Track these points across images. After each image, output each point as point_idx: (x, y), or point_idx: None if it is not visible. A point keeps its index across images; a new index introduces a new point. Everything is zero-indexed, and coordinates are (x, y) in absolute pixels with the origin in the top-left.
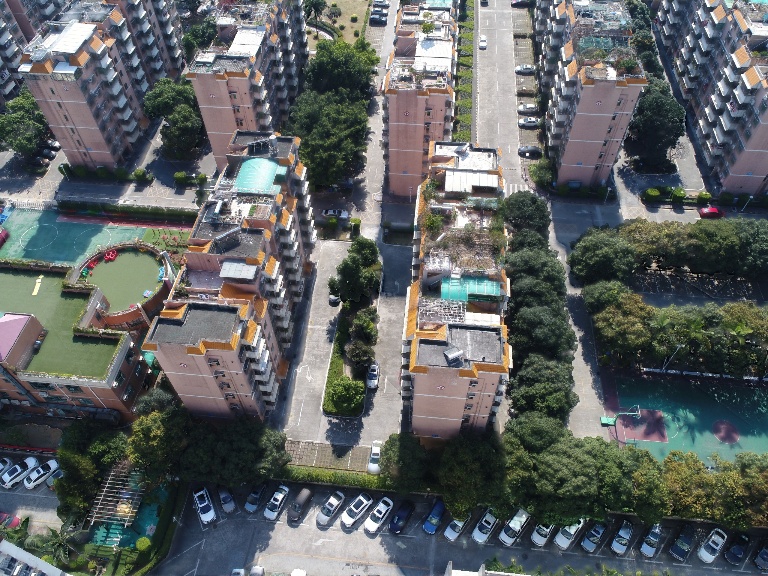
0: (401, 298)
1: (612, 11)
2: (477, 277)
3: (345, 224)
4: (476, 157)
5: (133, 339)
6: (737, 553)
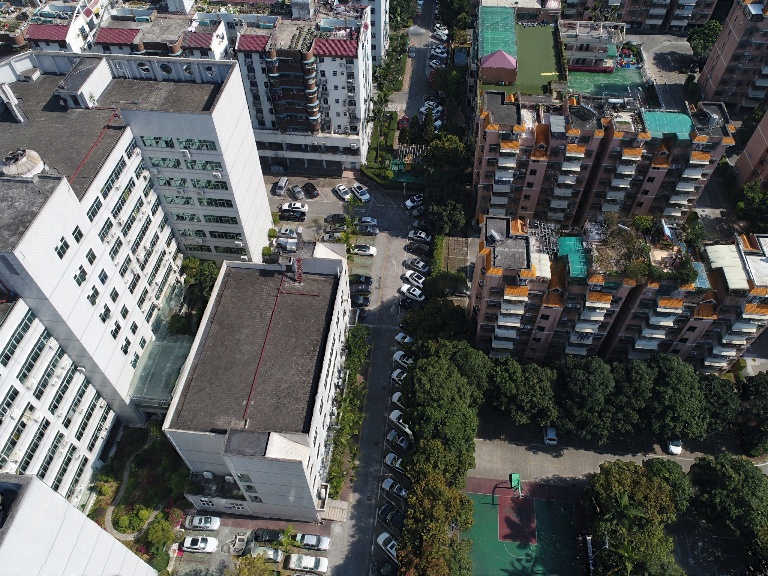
0: None
1: None
2: (589, 260)
3: None
4: None
5: None
6: (385, 569)
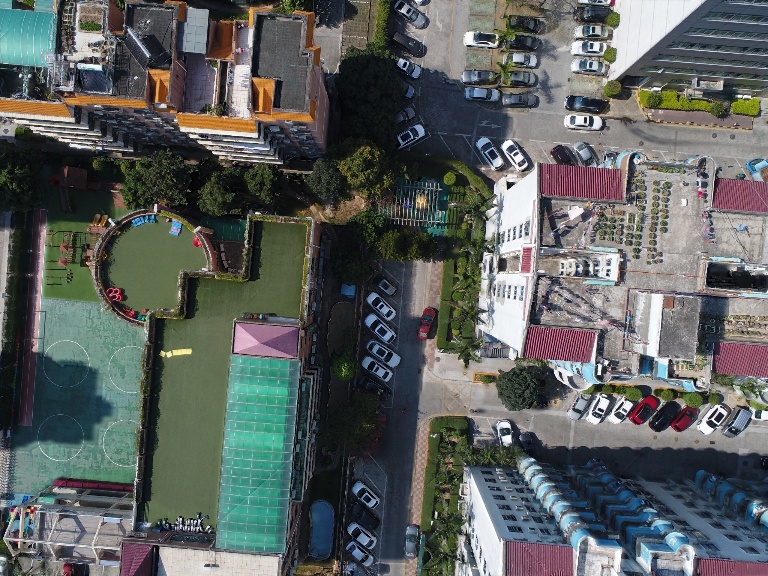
0: None
1: None
2: None
3: None
4: None
5: (230, 247)
6: None
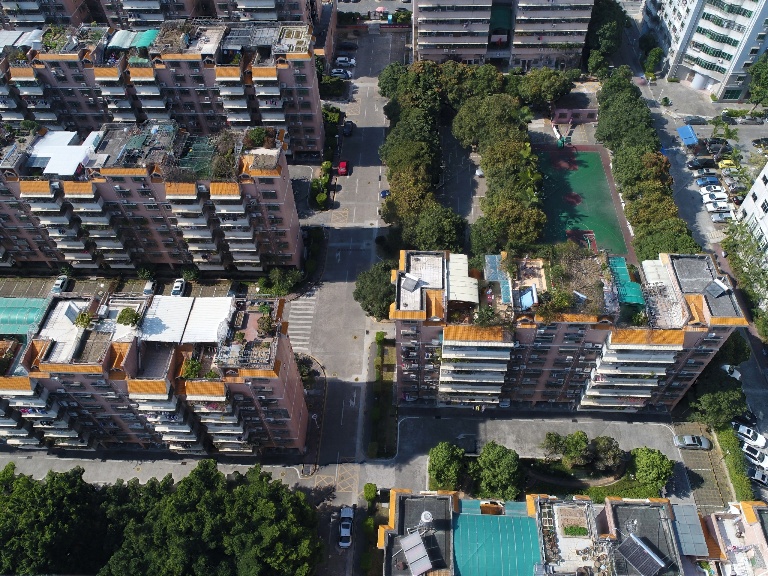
0: (483, 430)
1: (150, 131)
2: None
3: (362, 512)
4: (420, 271)
5: None
6: None
